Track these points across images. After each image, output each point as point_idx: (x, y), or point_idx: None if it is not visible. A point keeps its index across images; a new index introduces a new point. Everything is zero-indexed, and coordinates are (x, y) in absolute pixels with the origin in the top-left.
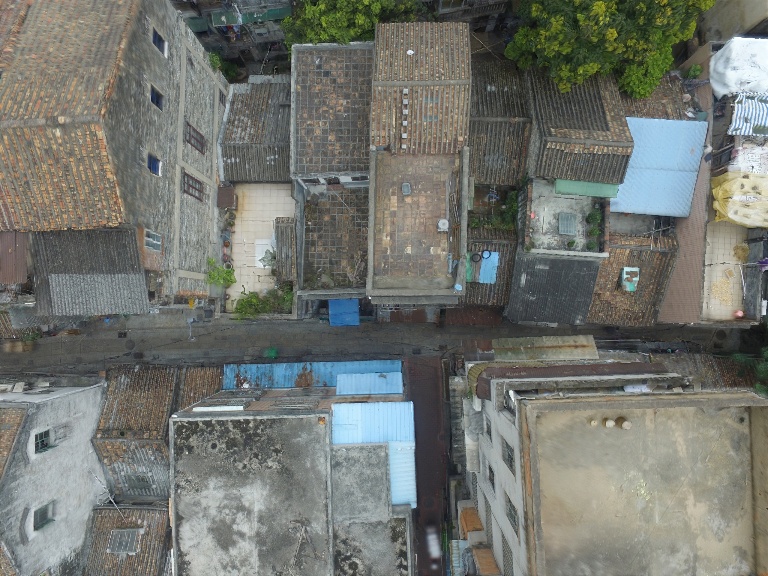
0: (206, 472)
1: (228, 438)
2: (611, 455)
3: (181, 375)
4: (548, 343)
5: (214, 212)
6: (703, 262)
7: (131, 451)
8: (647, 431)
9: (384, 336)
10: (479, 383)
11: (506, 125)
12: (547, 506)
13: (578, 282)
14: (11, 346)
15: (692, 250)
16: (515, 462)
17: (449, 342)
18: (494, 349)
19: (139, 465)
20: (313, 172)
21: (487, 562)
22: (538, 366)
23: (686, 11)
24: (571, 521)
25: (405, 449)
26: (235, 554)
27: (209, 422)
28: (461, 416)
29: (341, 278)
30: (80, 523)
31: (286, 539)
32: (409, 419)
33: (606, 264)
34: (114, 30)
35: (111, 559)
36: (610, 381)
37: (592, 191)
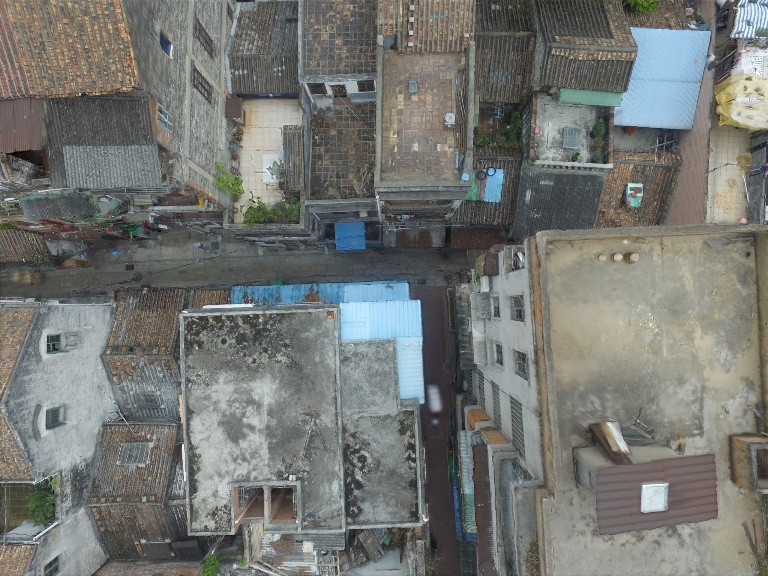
0: (216, 367)
1: (238, 333)
2: (619, 290)
3: (189, 297)
4: None
5: (222, 121)
6: (707, 168)
7: (140, 368)
8: (654, 266)
9: (389, 267)
10: (487, 259)
11: (510, 39)
12: (556, 340)
13: (582, 198)
14: (19, 279)
15: (696, 160)
16: (524, 305)
17: (454, 272)
18: None
19: (148, 384)
20: (320, 75)
21: (495, 437)
22: None
23: None
24: (580, 354)
25: (413, 345)
26: (245, 447)
27: (219, 318)
28: (468, 319)
29: (348, 191)
30: (90, 435)
31: (296, 432)
32: (417, 316)
33: (610, 180)
34: None
35: (121, 471)
36: None
37: (596, 100)
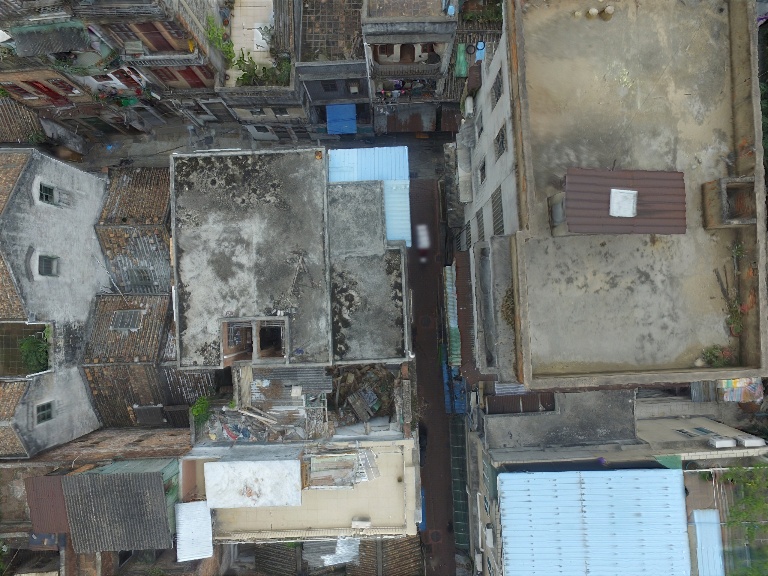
0: (206, 207)
1: (227, 174)
2: (594, 47)
3: None
4: None
5: None
6: None
7: (133, 241)
8: (629, 23)
9: None
10: (470, 74)
11: None
12: (533, 96)
13: None
14: None
15: None
16: (502, 72)
17: None
18: None
19: (141, 259)
20: None
21: None
22: None
23: None
24: (556, 109)
25: (400, 188)
26: (234, 284)
27: (209, 159)
28: (455, 174)
29: (338, 58)
30: (84, 300)
31: (284, 270)
32: (404, 160)
33: None
34: None
35: (114, 336)
36: None
37: None
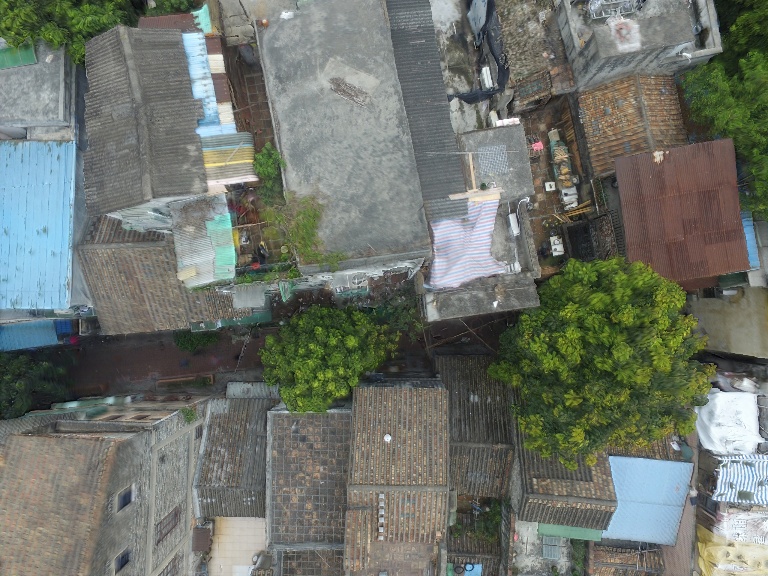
0: None
1: None
2: None
3: None
4: None
5: (188, 561)
6: None
7: None
8: None
9: None
10: None
11: (489, 450)
12: None
13: None
14: None
15: None
16: None
17: None
18: None
19: None
20: (289, 542)
21: None
22: None
23: None
24: None
25: None
26: None
27: None
28: None
29: None
30: None
31: None
32: None
33: None
34: (73, 547)
35: None
36: None
37: (576, 534)
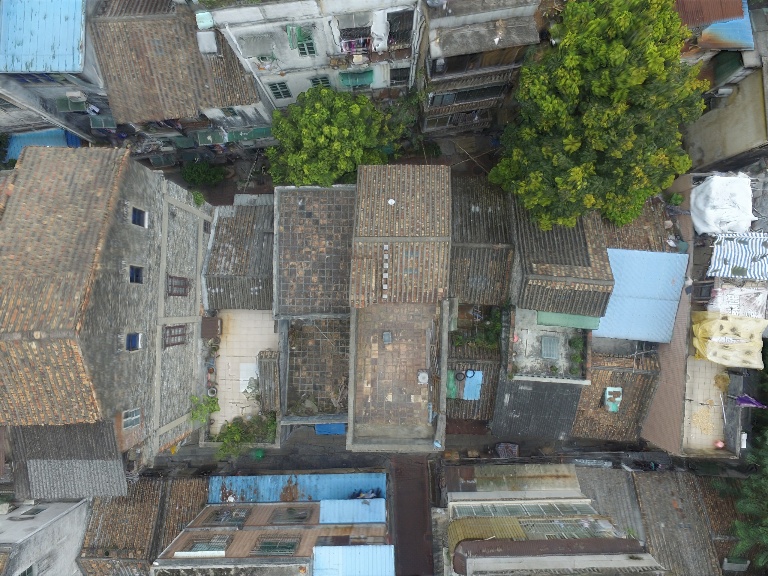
0: None
1: None
2: None
3: (167, 487)
4: (530, 472)
5: (198, 345)
6: (683, 395)
7: (116, 569)
8: None
9: None
10: (456, 557)
11: (489, 251)
12: None
13: (561, 402)
14: None
15: (673, 379)
16: None
17: None
18: (476, 478)
19: None
20: (295, 313)
21: None
22: (515, 537)
23: (663, 171)
24: None
25: None
26: None
27: (190, 570)
28: None
29: (325, 403)
30: None
31: None
32: (390, 564)
33: None
34: (92, 228)
35: None
36: (583, 574)
37: (574, 323)
